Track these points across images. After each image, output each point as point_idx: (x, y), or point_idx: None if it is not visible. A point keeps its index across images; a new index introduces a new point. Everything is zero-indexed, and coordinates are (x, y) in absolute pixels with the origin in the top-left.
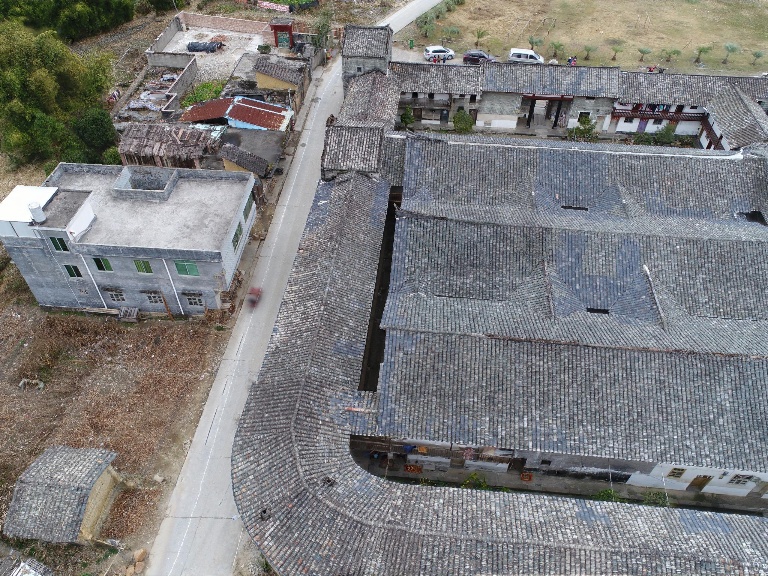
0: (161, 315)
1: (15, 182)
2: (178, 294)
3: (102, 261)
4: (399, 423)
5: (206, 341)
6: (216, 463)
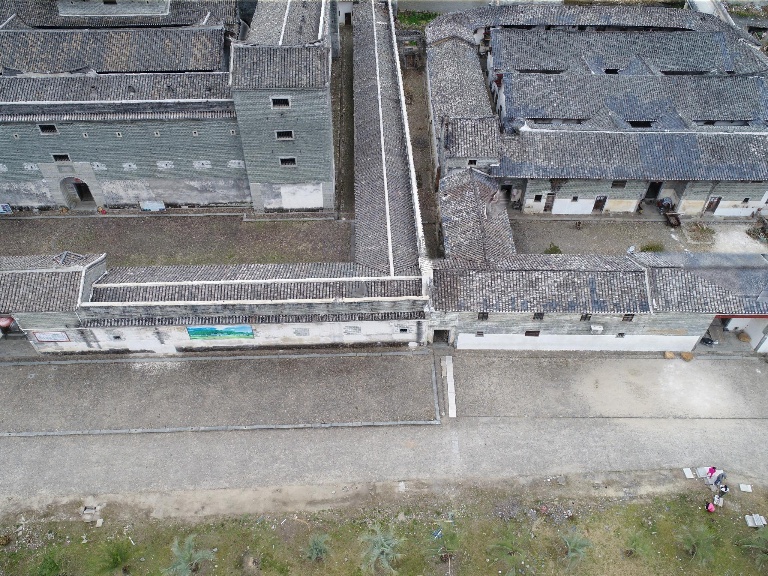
0: None
1: None
2: None
3: None
4: None
5: None
6: None
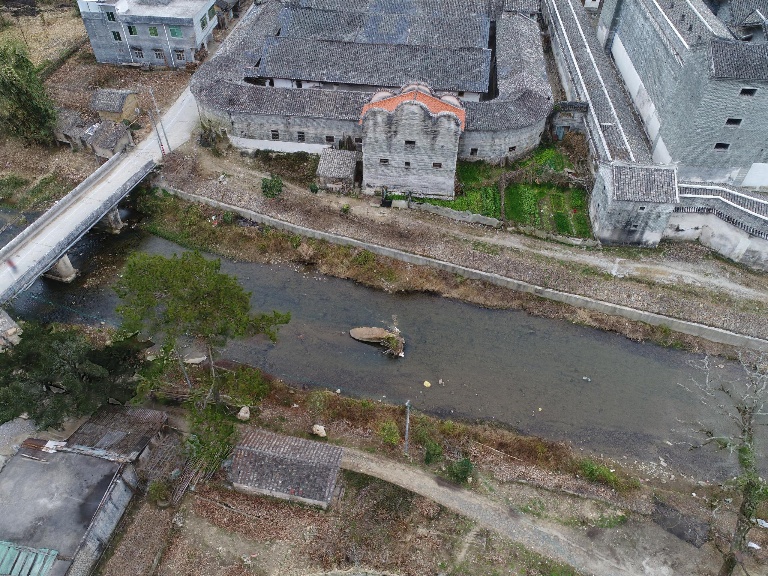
0: (162, 68)
1: (78, 21)
2: (171, 51)
3: (132, 28)
4: (267, 71)
5: (186, 77)
6: (186, 108)
